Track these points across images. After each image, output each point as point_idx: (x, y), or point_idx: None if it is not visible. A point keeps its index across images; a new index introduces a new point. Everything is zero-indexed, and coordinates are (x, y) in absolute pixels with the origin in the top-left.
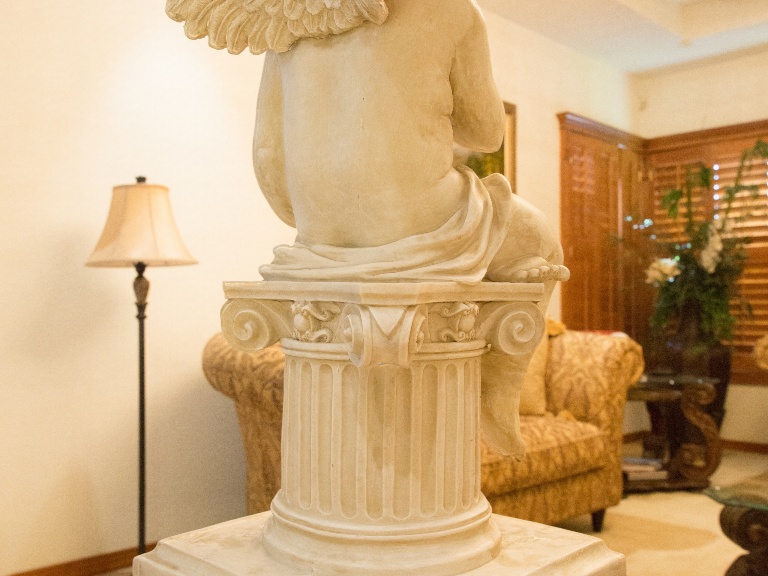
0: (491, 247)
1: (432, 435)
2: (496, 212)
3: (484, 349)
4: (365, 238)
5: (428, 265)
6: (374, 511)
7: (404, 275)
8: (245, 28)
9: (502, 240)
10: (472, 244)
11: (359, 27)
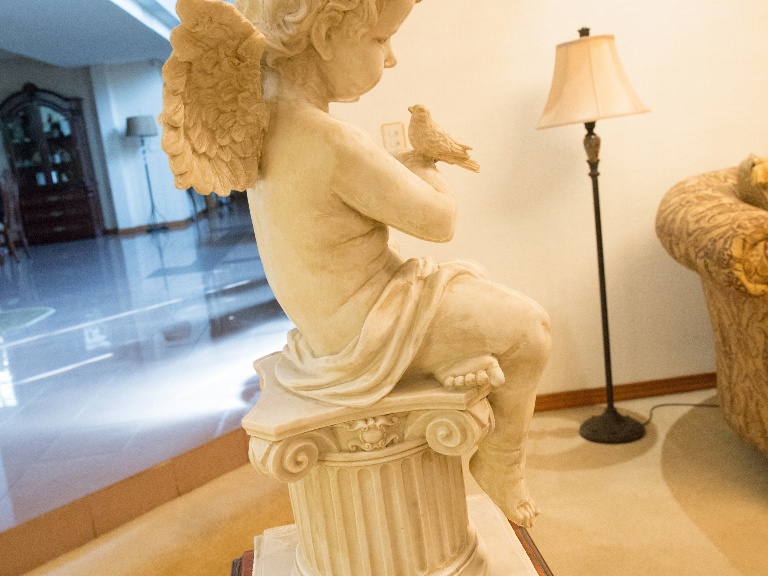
0: (400, 363)
1: (354, 523)
2: (413, 324)
3: (423, 446)
4: None
5: (333, 385)
6: (323, 569)
7: (311, 395)
8: None
9: (410, 356)
10: (376, 363)
11: None
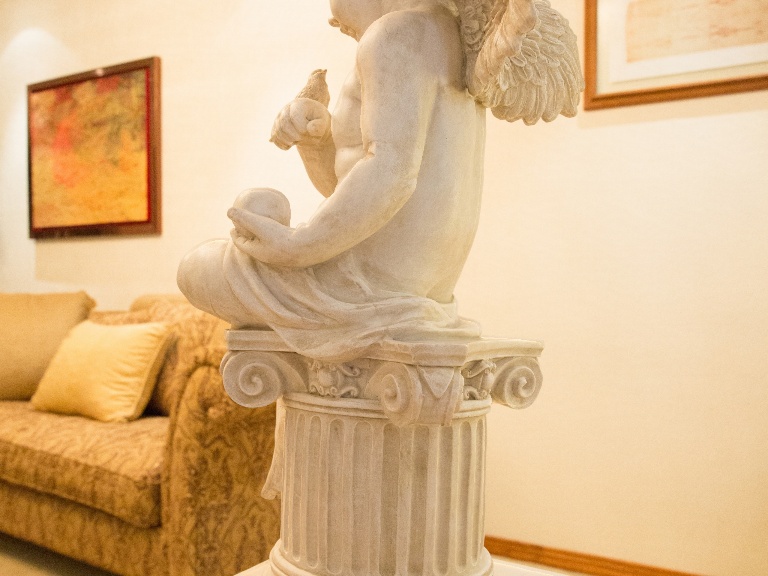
0: None
1: None
2: None
3: None
4: (445, 294)
5: None
6: None
7: None
8: None
9: None
10: None
11: None
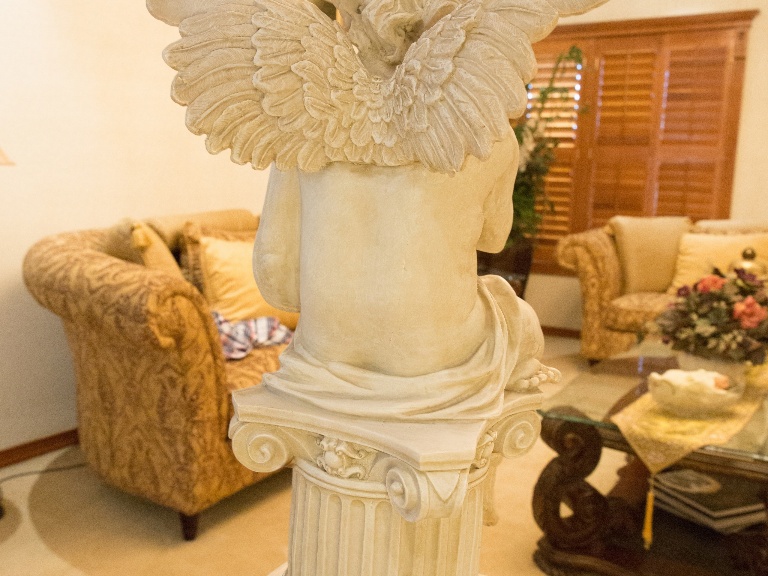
0: (506, 369)
1: (454, 556)
2: (508, 330)
3: None
4: (391, 366)
5: (458, 401)
6: None
7: (440, 416)
8: (275, 146)
9: (516, 361)
10: None
11: (407, 165)
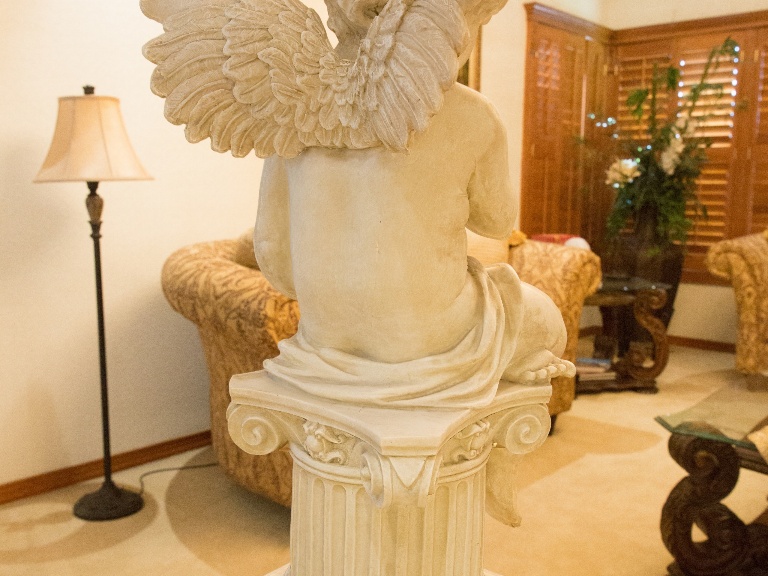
0: (503, 359)
1: (442, 549)
2: (508, 318)
3: None
4: (377, 352)
5: (442, 388)
6: None
7: (419, 403)
8: (251, 133)
9: (514, 351)
10: (485, 360)
11: (376, 147)
